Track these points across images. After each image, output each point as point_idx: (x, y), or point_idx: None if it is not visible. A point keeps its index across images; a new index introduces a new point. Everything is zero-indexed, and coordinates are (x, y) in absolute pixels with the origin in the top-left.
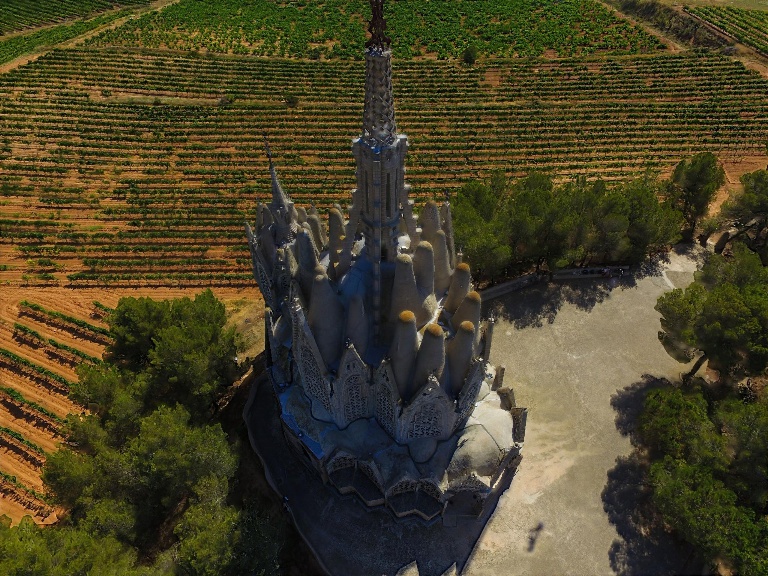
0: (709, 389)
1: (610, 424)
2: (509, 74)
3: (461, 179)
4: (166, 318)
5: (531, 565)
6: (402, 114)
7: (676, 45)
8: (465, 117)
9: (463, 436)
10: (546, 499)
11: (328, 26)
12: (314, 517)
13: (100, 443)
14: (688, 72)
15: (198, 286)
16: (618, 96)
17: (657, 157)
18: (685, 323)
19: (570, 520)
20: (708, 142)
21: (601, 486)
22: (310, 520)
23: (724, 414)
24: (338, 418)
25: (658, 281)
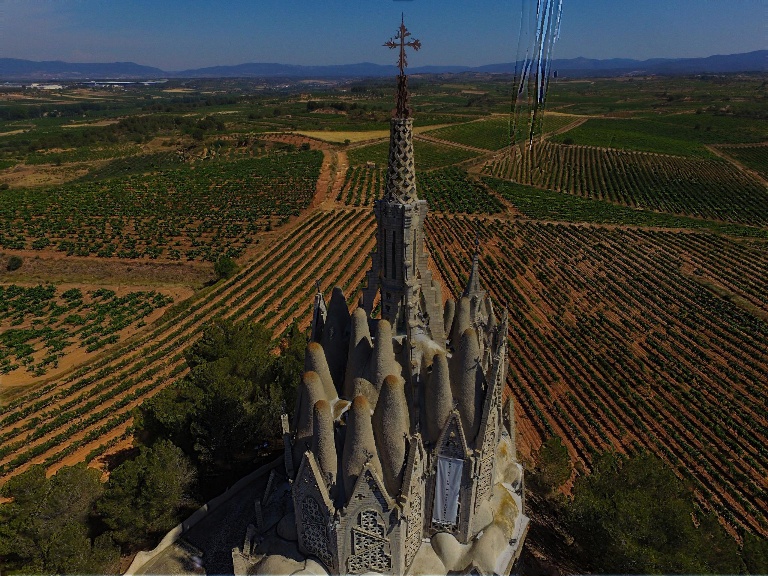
0: None
1: None
2: None
3: None
4: None
5: None
6: None
7: None
8: None
9: None
10: None
11: None
12: (263, 488)
13: None
14: None
15: (512, 389)
16: None
17: None
18: None
19: None
20: None
21: None
22: (261, 485)
23: None
24: None
25: None
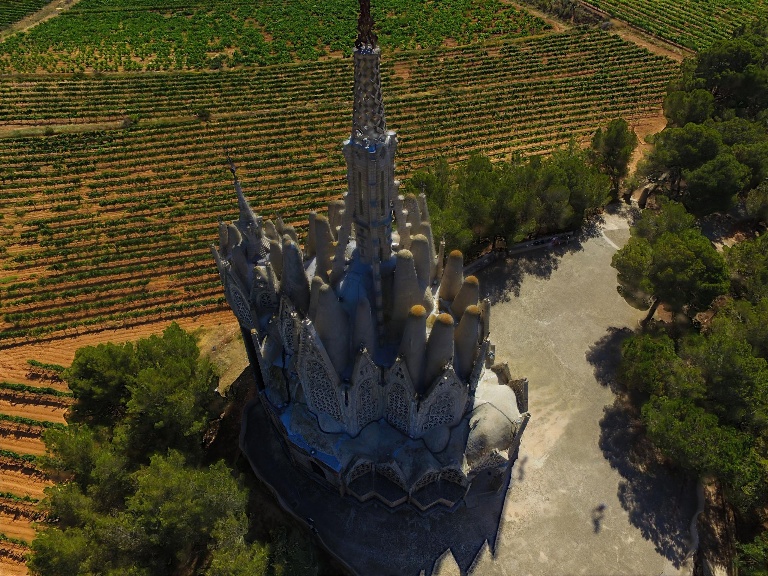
0: (671, 329)
1: (591, 378)
2: (417, 65)
3: (396, 172)
4: (134, 361)
5: (554, 524)
6: (322, 115)
7: (559, 25)
8: (385, 111)
9: (473, 418)
10: (553, 460)
11: (223, 33)
12: (339, 532)
13: (87, 511)
14: (576, 48)
15: (147, 322)
16: (521, 76)
17: (569, 129)
18: (640, 274)
19: (578, 474)
20: (608, 110)
21: (597, 436)
22: (336, 536)
23: (690, 348)
24: (351, 426)
25: (600, 241)
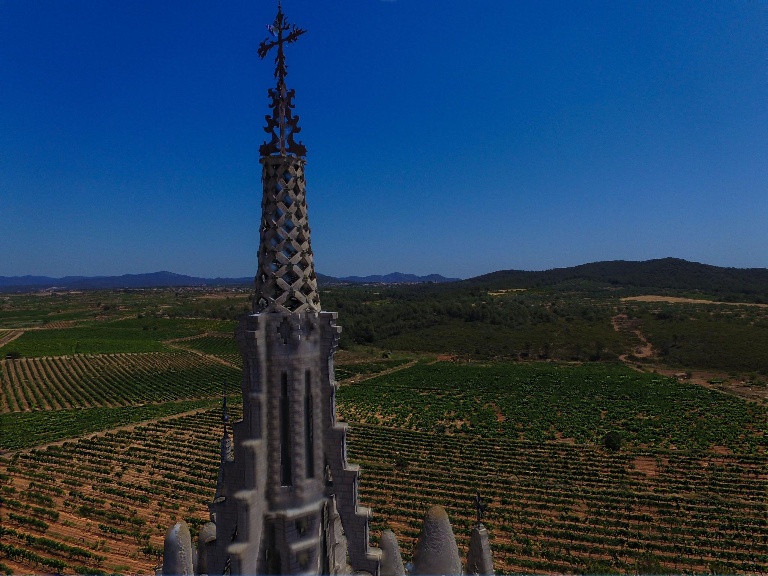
0: None
1: None
2: (667, 464)
3: None
4: None
5: None
6: (524, 490)
7: None
8: None
9: None
10: None
11: (461, 409)
12: None
13: None
14: None
15: None
16: None
17: None
18: None
19: None
20: None
21: None
22: None
23: None
24: None
25: None
